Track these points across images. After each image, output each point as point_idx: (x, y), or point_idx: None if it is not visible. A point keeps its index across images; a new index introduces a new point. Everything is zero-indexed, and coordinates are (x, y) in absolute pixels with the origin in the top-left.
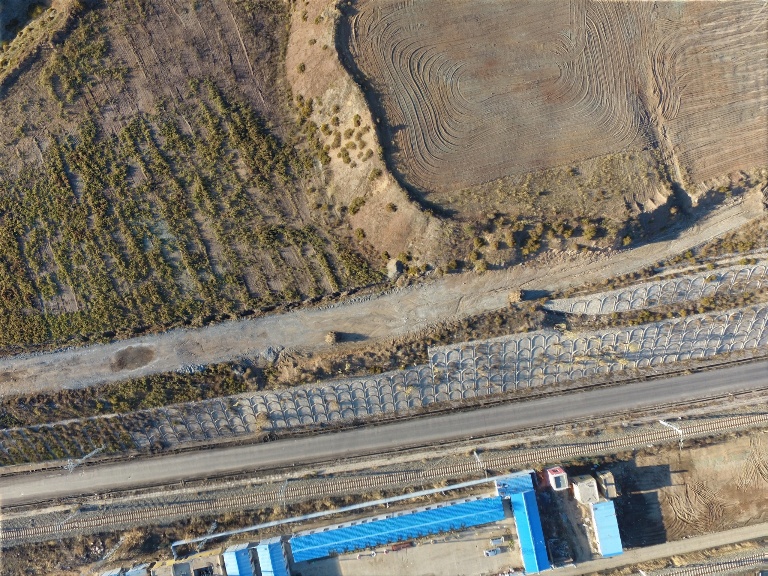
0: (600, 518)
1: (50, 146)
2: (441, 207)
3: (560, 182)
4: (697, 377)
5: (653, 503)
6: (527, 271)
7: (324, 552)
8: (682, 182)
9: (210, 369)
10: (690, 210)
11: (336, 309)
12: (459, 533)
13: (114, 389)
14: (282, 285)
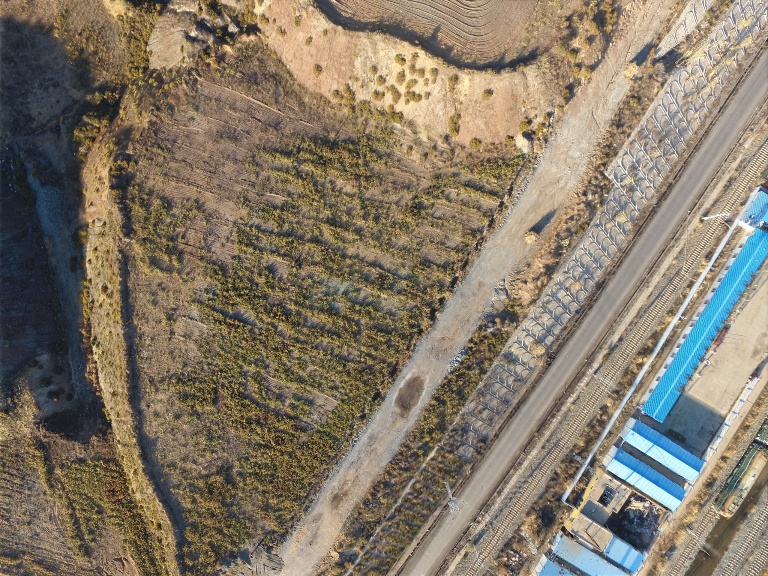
0: None
1: (199, 311)
2: (523, 56)
3: None
4: None
5: None
6: (620, 45)
7: (675, 394)
8: None
9: (470, 347)
10: None
11: (512, 214)
12: None
13: (420, 429)
14: (457, 237)
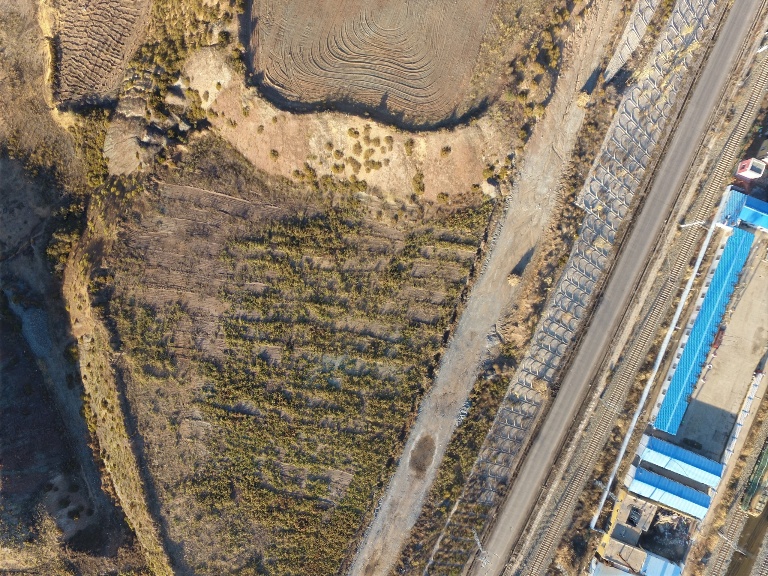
0: None
1: (200, 410)
2: (474, 109)
3: None
4: None
5: None
6: (567, 76)
7: (683, 405)
8: None
9: (473, 398)
10: None
11: (492, 260)
12: (740, 283)
13: (438, 487)
14: (441, 292)
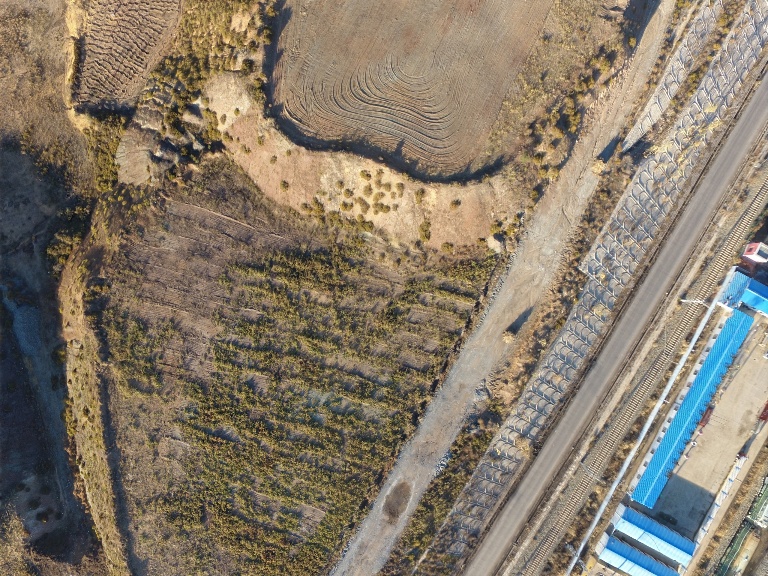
0: None
1: (181, 430)
2: (488, 166)
3: (546, 56)
4: (767, 79)
5: None
6: (586, 141)
7: (663, 480)
8: None
9: (454, 450)
10: None
11: (489, 314)
12: (734, 364)
13: (409, 535)
14: (435, 341)
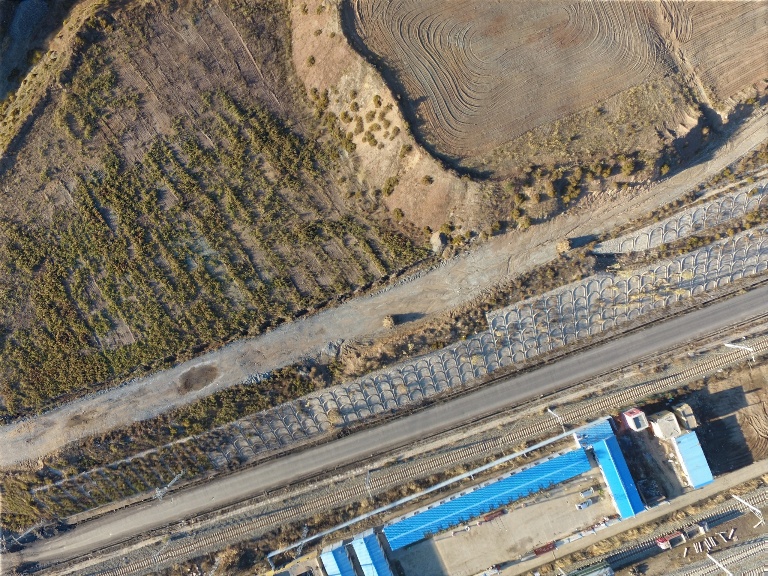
0: (685, 450)
1: (77, 185)
2: (477, 170)
3: (589, 124)
4: (753, 294)
5: (733, 426)
6: (570, 219)
7: (419, 535)
8: (709, 101)
9: (275, 375)
10: (721, 128)
11: (388, 292)
12: (548, 492)
13: (185, 412)
14: (330, 279)
